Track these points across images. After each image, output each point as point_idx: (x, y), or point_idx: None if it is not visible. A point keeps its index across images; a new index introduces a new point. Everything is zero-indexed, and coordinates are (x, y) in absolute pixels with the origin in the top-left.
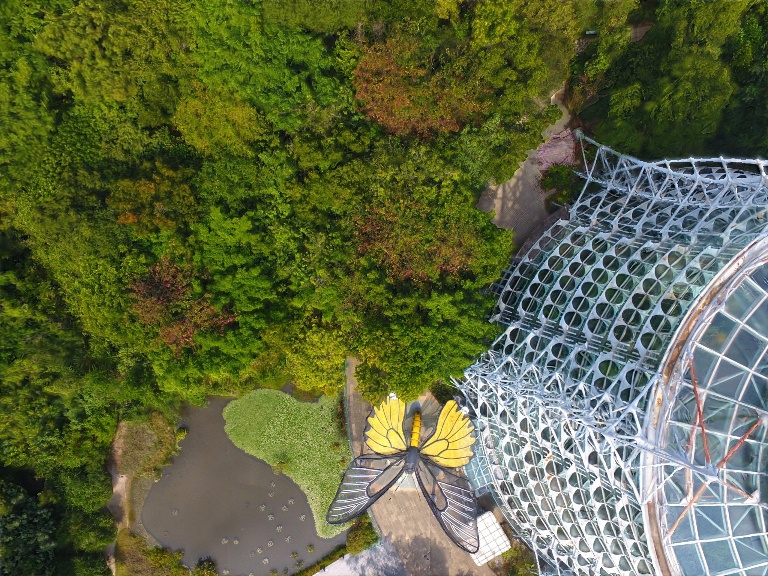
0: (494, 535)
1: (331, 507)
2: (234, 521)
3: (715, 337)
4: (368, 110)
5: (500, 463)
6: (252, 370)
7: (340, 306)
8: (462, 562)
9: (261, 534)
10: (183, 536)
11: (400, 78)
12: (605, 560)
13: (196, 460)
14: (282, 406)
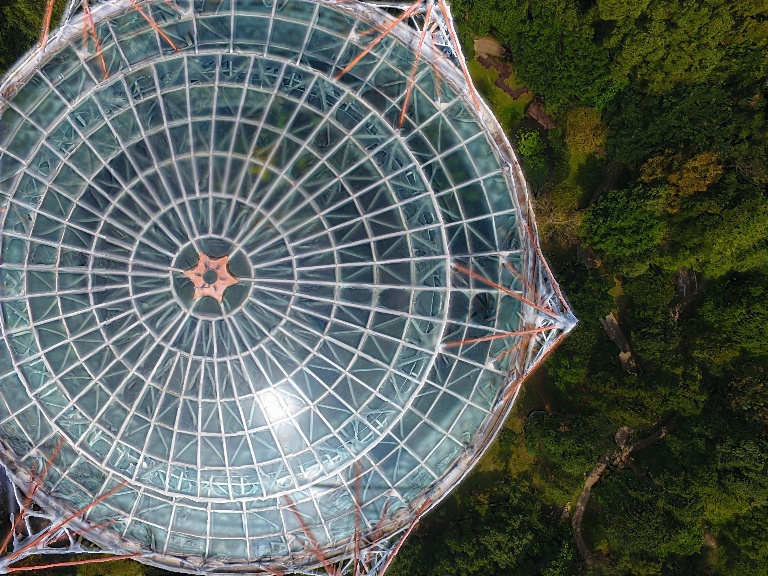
0: None
1: None
2: None
3: (7, 134)
4: None
5: None
6: None
7: None
8: None
9: None
10: None
11: None
12: None
13: None
14: None
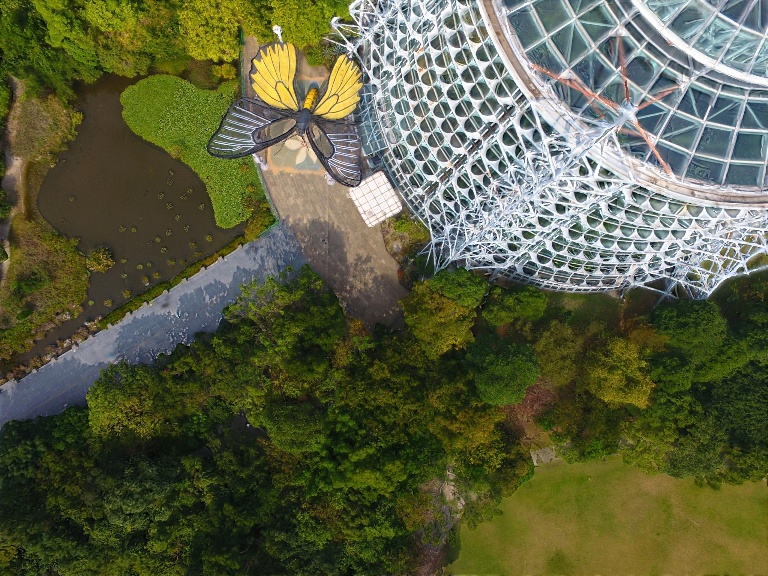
0: (385, 196)
1: (212, 139)
2: (132, 210)
3: None
4: None
5: (392, 125)
6: (142, 29)
7: None
8: (360, 247)
9: (159, 223)
10: (80, 224)
11: None
12: (468, 126)
13: (93, 146)
14: (181, 92)
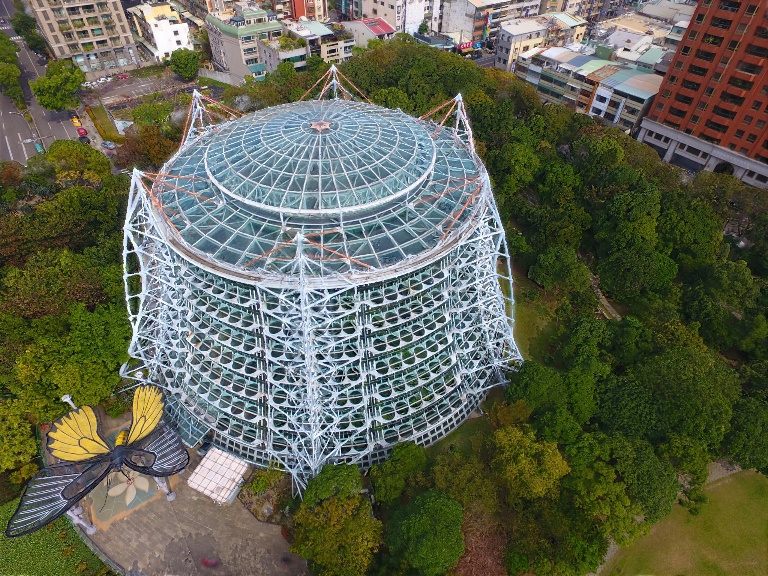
0: (226, 465)
1: (12, 521)
2: None
3: None
4: (6, 266)
5: None
6: None
7: (1, 370)
8: (230, 537)
9: None
10: None
11: (11, 230)
12: None
13: None
14: None
